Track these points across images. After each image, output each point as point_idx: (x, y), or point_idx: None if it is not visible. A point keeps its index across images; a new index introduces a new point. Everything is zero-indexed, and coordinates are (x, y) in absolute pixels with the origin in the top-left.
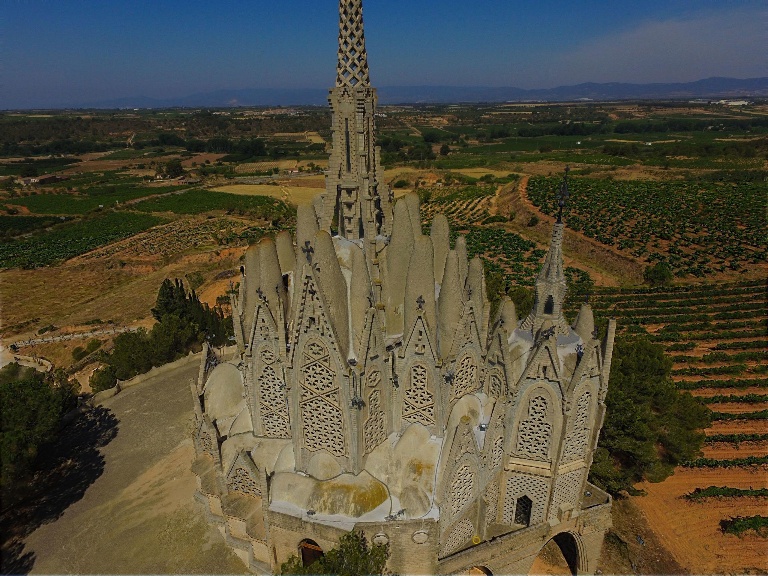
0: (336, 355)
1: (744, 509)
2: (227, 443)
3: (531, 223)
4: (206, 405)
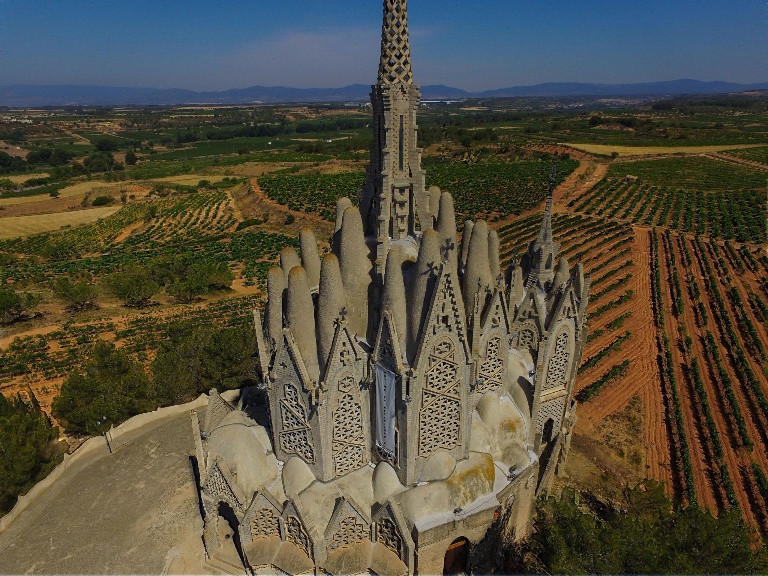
0: (461, 347)
1: (579, 384)
2: (305, 504)
3: (289, 221)
4: (238, 481)
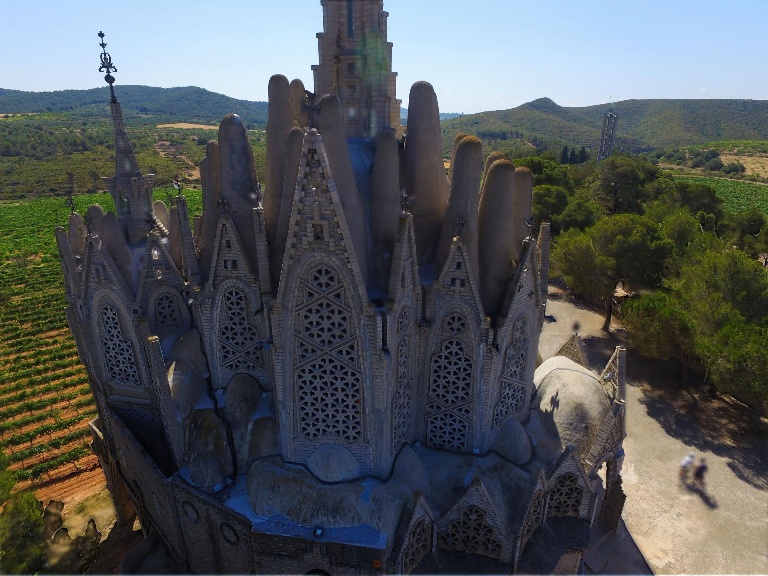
0: None
1: None
2: None
3: None
4: None
